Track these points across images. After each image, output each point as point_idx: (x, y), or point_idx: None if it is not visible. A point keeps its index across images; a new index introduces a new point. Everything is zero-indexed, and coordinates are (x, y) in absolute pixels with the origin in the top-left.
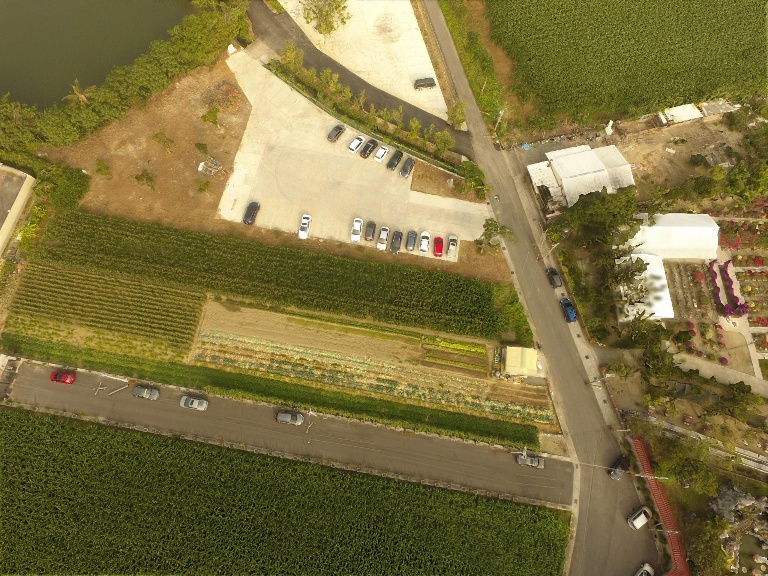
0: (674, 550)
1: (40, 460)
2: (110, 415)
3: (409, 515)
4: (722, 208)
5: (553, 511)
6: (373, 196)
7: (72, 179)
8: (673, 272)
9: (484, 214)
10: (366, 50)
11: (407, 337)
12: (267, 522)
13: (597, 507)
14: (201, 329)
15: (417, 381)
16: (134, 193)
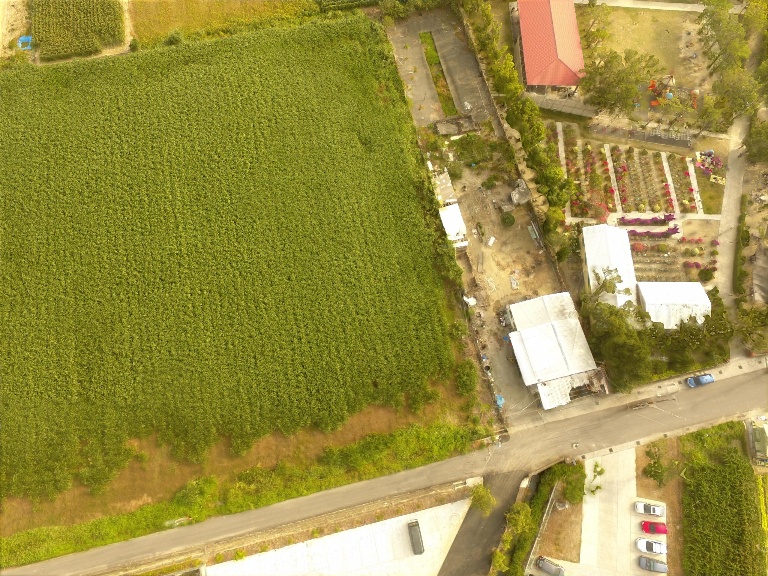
0: None
1: None
2: None
3: None
4: None
5: None
6: None
7: None
8: (636, 269)
9: (598, 464)
10: None
11: (767, 572)
12: None
13: None
14: None
15: None
16: None
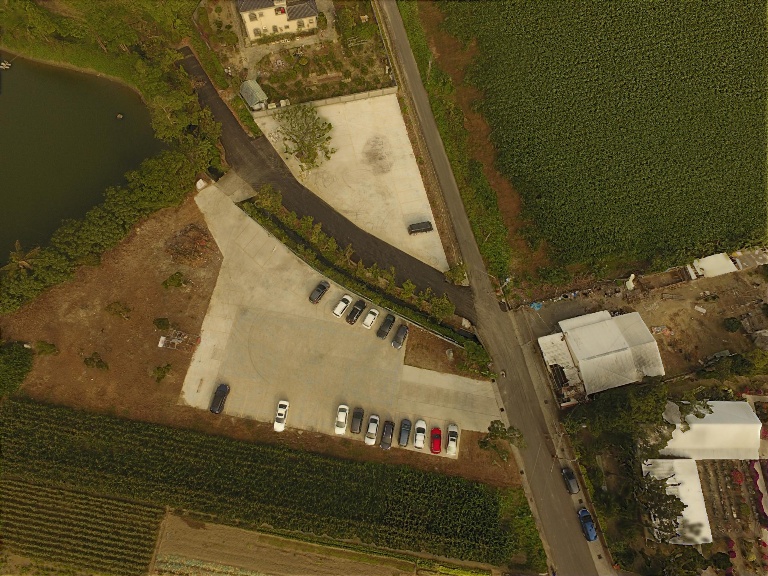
0: None
1: None
2: None
3: None
4: (761, 384)
5: None
6: (361, 373)
7: (11, 361)
8: (708, 471)
9: (488, 395)
10: (354, 183)
11: (399, 560)
12: None
13: None
14: (158, 553)
15: None
16: (84, 372)
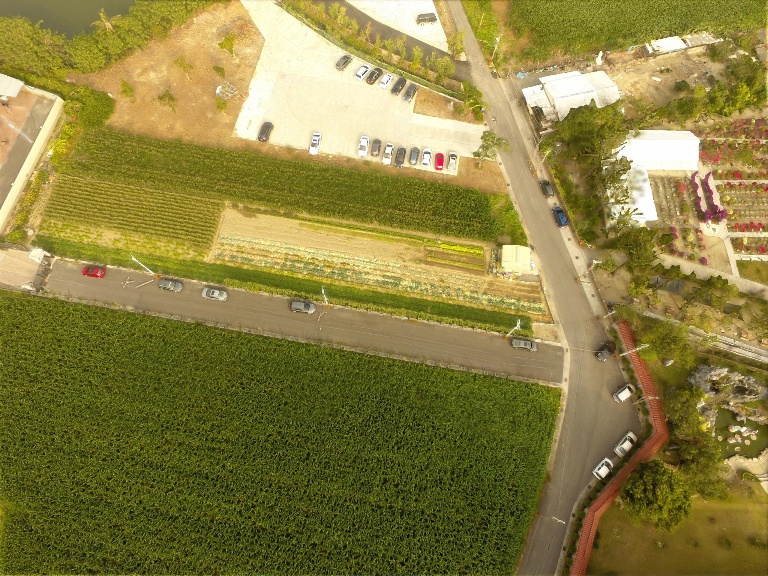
0: (655, 416)
1: (75, 341)
2: (138, 305)
3: (413, 388)
4: (704, 129)
5: (545, 387)
6: (378, 118)
7: (99, 100)
8: (657, 184)
9: None
10: None
11: (410, 240)
12: (283, 393)
13: (585, 385)
14: (220, 232)
15: (420, 278)
16: (156, 114)
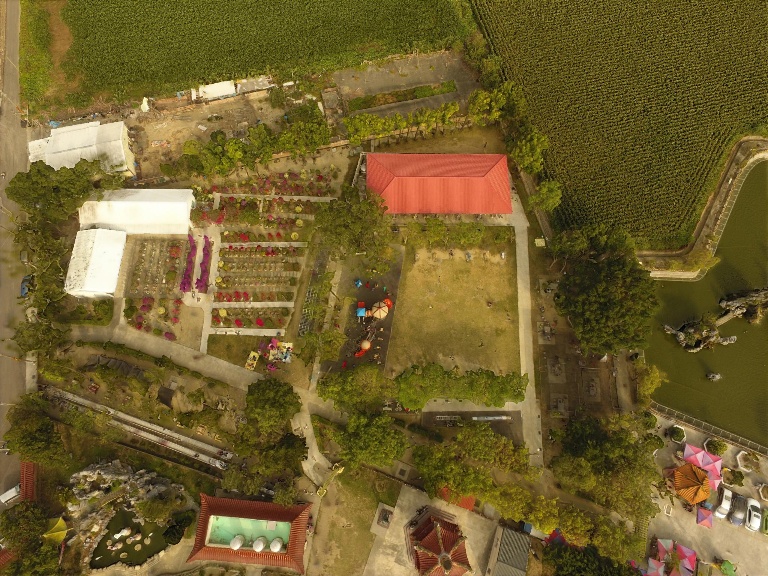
0: None
1: None
2: None
3: None
4: (232, 184)
5: None
6: None
7: None
8: (153, 248)
9: None
10: None
11: None
12: None
13: None
14: None
15: None
16: None
